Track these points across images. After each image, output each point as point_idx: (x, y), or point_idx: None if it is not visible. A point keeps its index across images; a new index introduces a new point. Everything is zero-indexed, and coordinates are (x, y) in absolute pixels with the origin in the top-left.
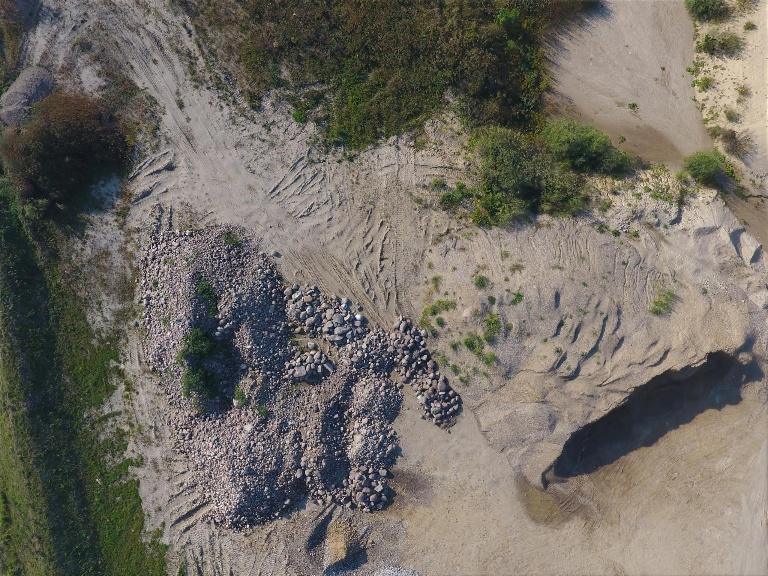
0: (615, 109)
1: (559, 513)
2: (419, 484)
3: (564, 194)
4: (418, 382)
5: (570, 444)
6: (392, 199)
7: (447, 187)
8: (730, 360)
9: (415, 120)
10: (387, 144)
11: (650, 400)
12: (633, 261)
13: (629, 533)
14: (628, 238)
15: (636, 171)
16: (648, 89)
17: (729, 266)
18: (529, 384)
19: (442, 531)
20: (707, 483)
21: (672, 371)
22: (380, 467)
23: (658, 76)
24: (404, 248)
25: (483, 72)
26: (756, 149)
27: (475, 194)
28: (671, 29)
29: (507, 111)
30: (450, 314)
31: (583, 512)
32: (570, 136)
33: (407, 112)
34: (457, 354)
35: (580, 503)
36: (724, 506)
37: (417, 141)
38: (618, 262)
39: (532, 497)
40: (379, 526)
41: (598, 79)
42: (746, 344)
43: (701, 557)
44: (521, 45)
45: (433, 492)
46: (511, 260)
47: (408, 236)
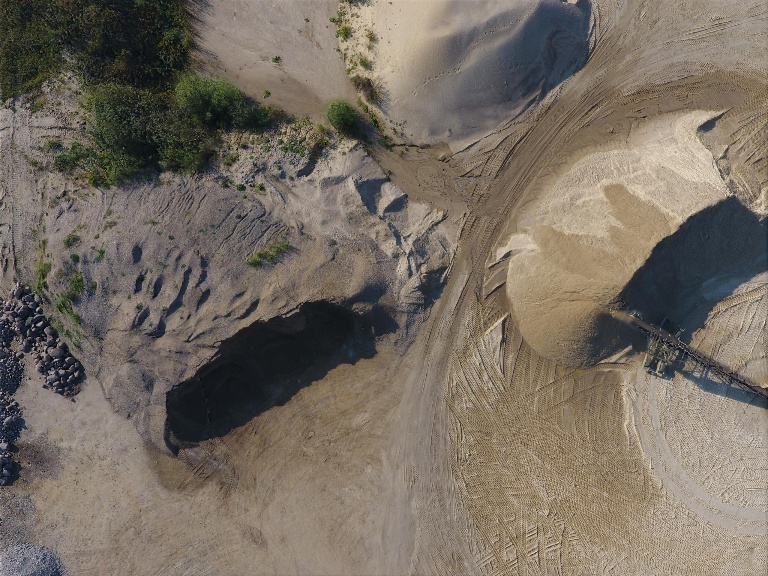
0: (259, 63)
1: (193, 479)
2: (45, 456)
3: (181, 149)
4: (38, 350)
5: (182, 405)
6: (7, 163)
7: (62, 148)
8: (347, 311)
9: (31, 81)
10: (3, 107)
11: (271, 356)
12: (253, 215)
13: (266, 496)
14: (254, 192)
15: (279, 125)
16: (291, 41)
17: (356, 216)
18: (115, 343)
19: (71, 504)
20: (345, 440)
21: (262, 323)
22: (1, 440)
23: (301, 28)
24: (21, 213)
25: (100, 29)
26: (388, 96)
27: (91, 154)
28: None
29: (136, 69)
30: (48, 276)
31: (217, 477)
32: (187, 90)
33: (21, 73)
34: (65, 318)
35: (214, 468)
36: (364, 463)
37: (35, 103)
38: (232, 216)
39: (164, 464)
40: (6, 502)
41: (242, 34)
42: (368, 294)
43: (342, 517)
44: (157, 2)
45: (60, 464)
46: (110, 218)
47: (25, 200)
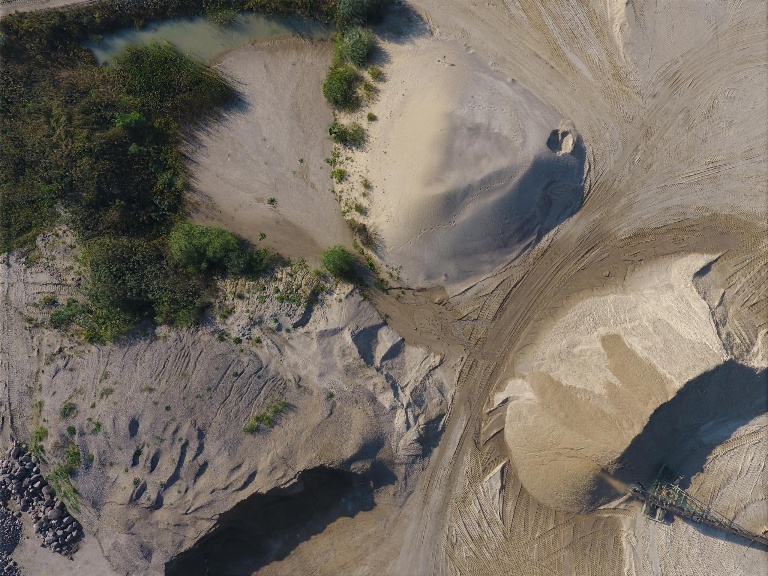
0: (254, 205)
1: None
2: None
3: (177, 305)
4: (35, 509)
5: (181, 569)
6: (2, 320)
7: (57, 304)
8: None
9: (25, 235)
10: None
11: (269, 515)
12: (250, 370)
13: None
14: (250, 345)
15: (275, 269)
16: (286, 183)
17: (353, 368)
18: (113, 516)
19: None
20: None
21: (260, 493)
22: None
23: (296, 169)
24: (17, 370)
25: (94, 182)
26: (384, 243)
27: (87, 310)
28: (309, 119)
29: (131, 217)
30: (45, 443)
31: None
32: (182, 244)
33: (15, 228)
34: (62, 482)
35: None
36: None
37: (29, 257)
38: (228, 374)
39: None
40: None
41: (236, 175)
42: (366, 450)
43: None
44: (151, 146)
45: None
46: (107, 382)
47: (20, 357)
